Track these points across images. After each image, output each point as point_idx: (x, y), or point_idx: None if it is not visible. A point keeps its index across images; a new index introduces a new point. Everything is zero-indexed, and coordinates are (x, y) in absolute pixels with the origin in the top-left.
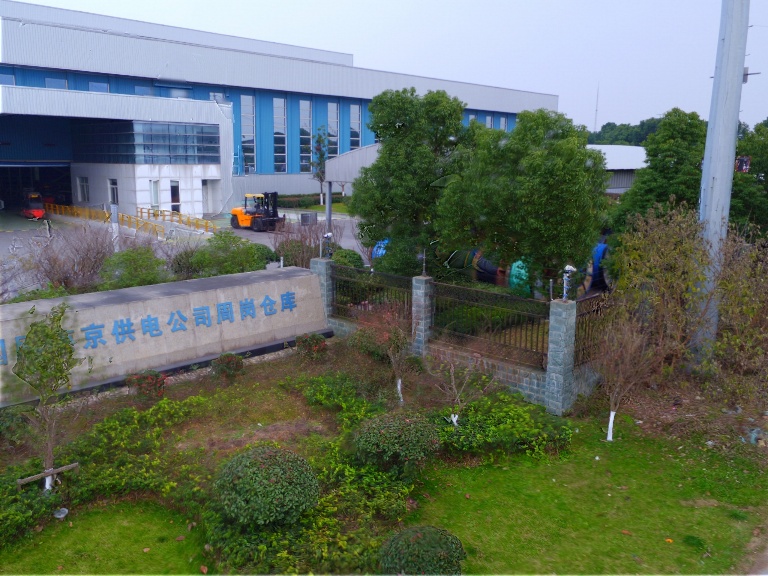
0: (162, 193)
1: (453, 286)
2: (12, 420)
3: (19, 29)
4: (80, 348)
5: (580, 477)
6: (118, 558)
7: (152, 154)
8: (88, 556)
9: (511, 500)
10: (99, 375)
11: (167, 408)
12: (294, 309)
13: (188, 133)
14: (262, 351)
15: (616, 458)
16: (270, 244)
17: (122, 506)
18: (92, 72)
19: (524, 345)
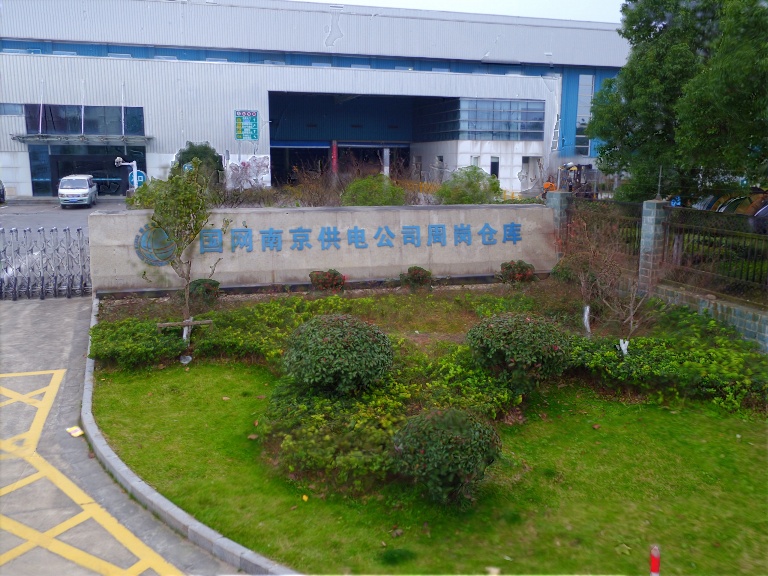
0: None
1: (689, 209)
2: (195, 288)
3: (376, 23)
4: (287, 248)
5: None
6: (198, 398)
7: (475, 130)
8: (178, 392)
9: (653, 441)
10: (302, 277)
11: (331, 302)
12: (518, 242)
13: (513, 109)
14: (473, 280)
15: None
16: None
17: (237, 365)
18: (435, 58)
19: None
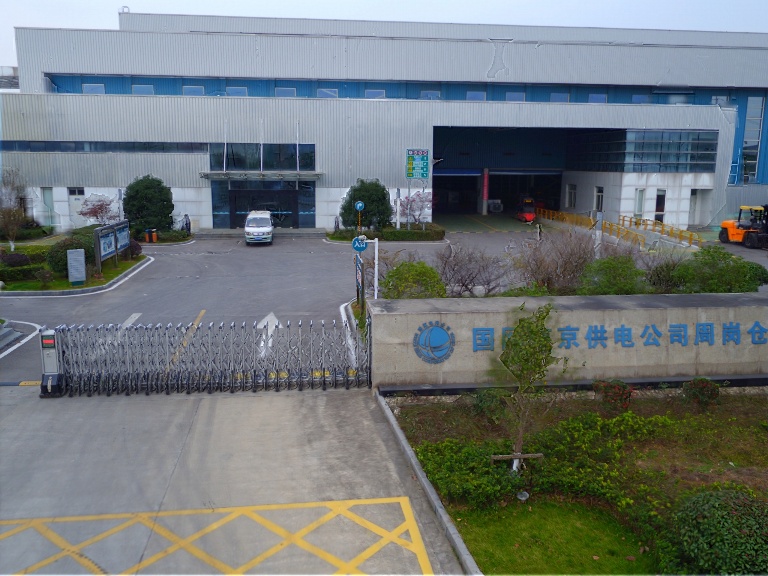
0: (647, 202)
1: None
2: (492, 401)
3: (534, 50)
4: (555, 347)
5: None
6: (568, 556)
7: (642, 162)
8: (542, 544)
9: None
10: (568, 375)
11: (631, 422)
12: None
13: (683, 140)
14: (743, 383)
15: None
16: (766, 264)
17: (577, 507)
18: None
19: None
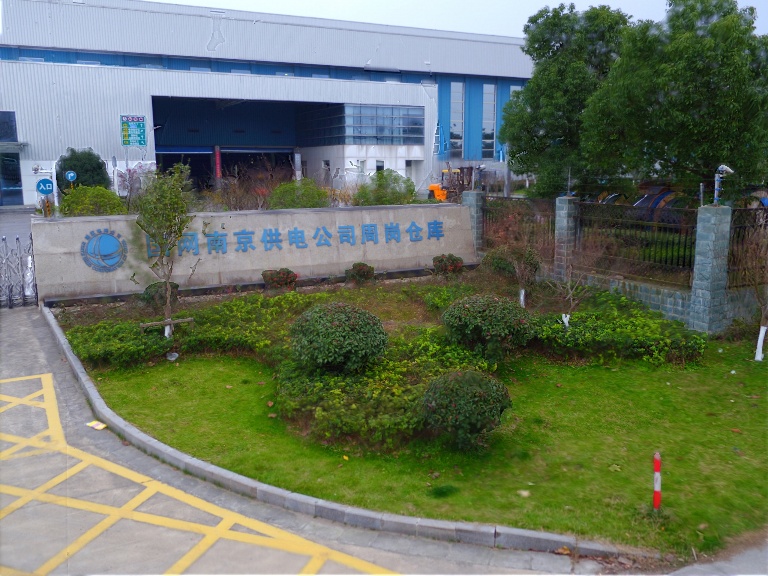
0: (368, 172)
1: (597, 203)
2: (157, 291)
3: (256, 28)
4: (232, 250)
5: (702, 383)
6: (203, 388)
7: (360, 135)
8: (180, 384)
9: (607, 392)
10: (248, 277)
11: (291, 298)
12: (441, 238)
13: (395, 115)
14: (404, 274)
15: (758, 374)
16: None
17: (224, 358)
18: (315, 64)
19: (670, 262)
